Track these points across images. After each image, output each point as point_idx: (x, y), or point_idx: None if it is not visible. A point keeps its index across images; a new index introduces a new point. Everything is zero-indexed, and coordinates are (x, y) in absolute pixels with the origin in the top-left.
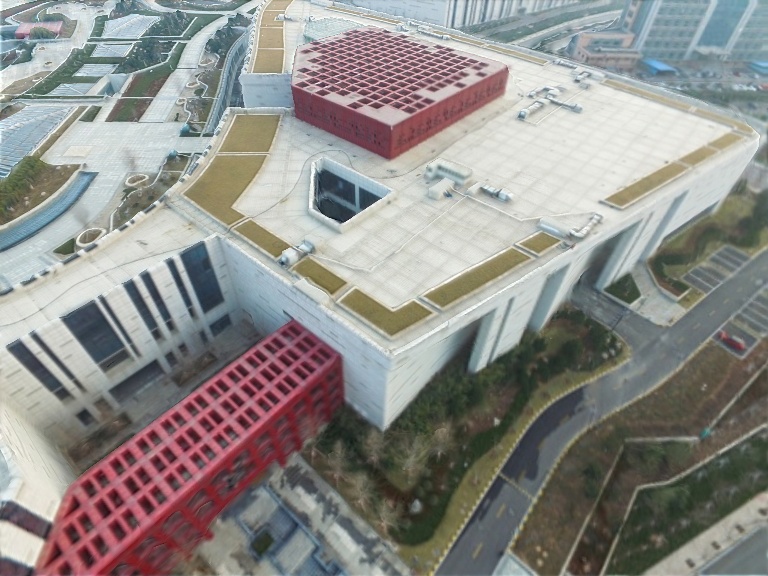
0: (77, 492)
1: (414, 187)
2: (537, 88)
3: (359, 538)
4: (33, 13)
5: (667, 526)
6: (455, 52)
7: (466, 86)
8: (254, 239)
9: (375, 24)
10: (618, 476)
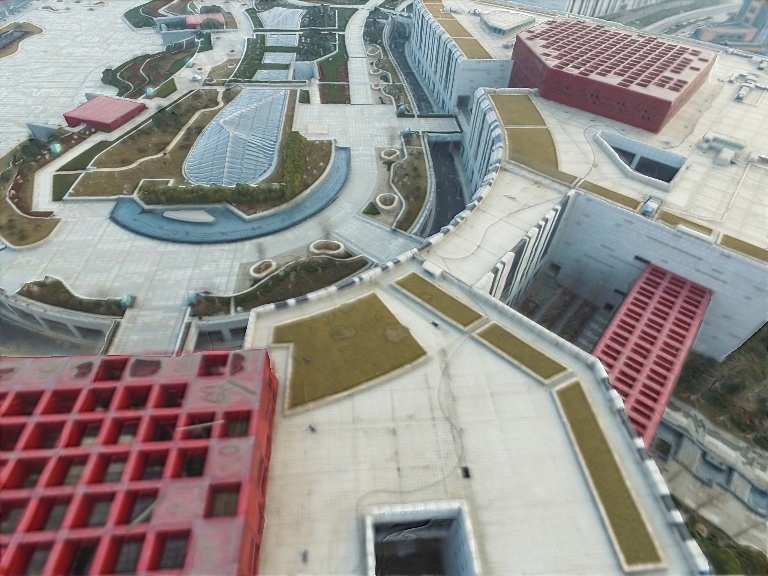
0: None
1: (696, 156)
2: (734, 74)
3: (733, 446)
4: (181, 6)
5: None
6: (661, 40)
7: (701, 69)
8: (603, 195)
9: (534, 17)
10: None
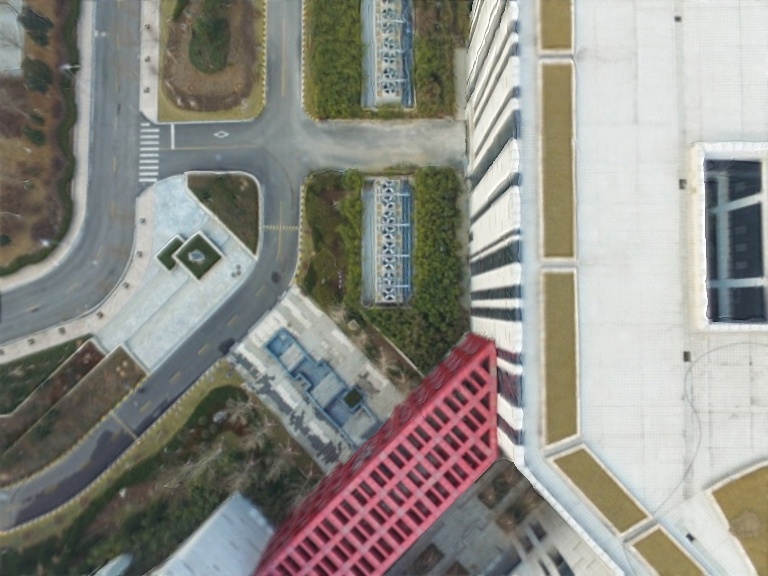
0: (488, 451)
1: None
2: None
3: (273, 395)
4: None
5: (2, 381)
6: None
7: None
8: None
9: None
10: (23, 427)
